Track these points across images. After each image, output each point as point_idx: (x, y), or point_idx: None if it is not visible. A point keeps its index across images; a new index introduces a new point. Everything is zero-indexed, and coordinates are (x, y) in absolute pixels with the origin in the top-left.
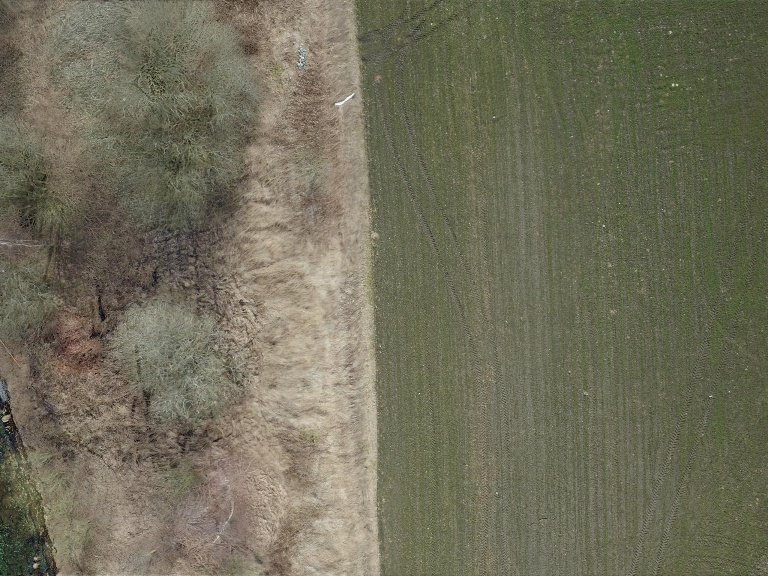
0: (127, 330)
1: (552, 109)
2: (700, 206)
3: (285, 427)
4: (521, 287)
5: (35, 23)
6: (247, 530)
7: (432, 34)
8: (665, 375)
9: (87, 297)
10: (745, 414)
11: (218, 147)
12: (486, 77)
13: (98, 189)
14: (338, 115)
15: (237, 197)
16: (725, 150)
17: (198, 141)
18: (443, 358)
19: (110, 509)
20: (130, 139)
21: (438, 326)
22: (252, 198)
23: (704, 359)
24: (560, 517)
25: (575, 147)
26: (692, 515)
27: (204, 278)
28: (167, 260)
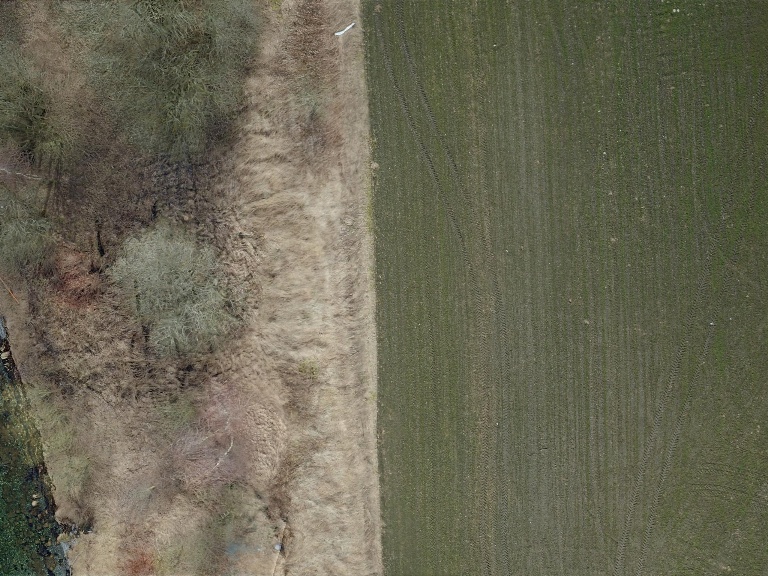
0: (126, 265)
1: (553, 36)
2: (701, 132)
3: (285, 360)
4: (521, 216)
5: None
6: (246, 465)
7: None
8: (666, 303)
9: (86, 232)
10: (746, 341)
11: (218, 80)
12: (486, 5)
13: (97, 124)
14: (338, 45)
15: (237, 129)
16: (726, 76)
17: (197, 74)
18: (443, 288)
19: (109, 445)
20: (129, 73)
21: (438, 256)
22: (252, 130)
23: (705, 286)
24: (560, 447)
25: (576, 74)
26: (693, 443)
27: (203, 212)
28: (166, 194)
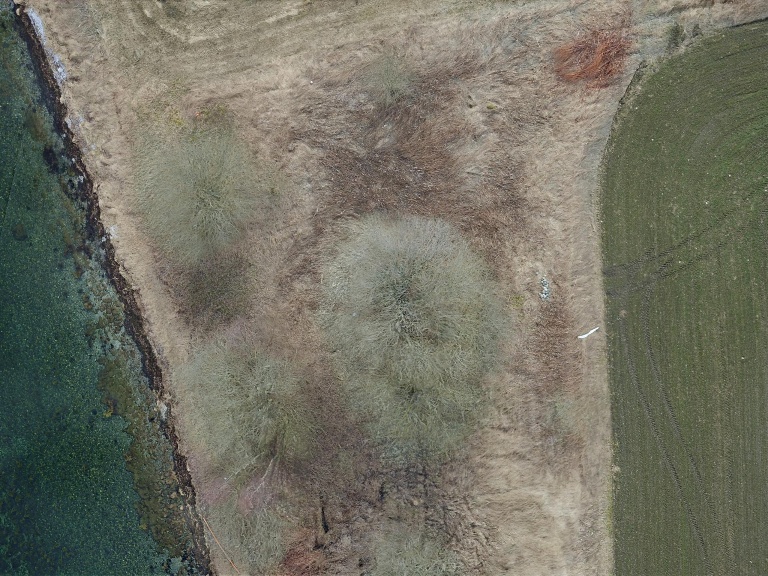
0: (351, 543)
1: None
2: None
3: None
4: (767, 529)
5: (264, 235)
6: None
7: (680, 272)
8: None
9: (310, 508)
10: None
11: None
12: (735, 318)
13: (324, 402)
14: (581, 348)
15: (472, 422)
16: None
17: None
18: None
19: None
20: (359, 354)
21: (679, 562)
22: (489, 424)
23: None
24: None
25: None
26: None
27: (433, 497)
28: (395, 477)
